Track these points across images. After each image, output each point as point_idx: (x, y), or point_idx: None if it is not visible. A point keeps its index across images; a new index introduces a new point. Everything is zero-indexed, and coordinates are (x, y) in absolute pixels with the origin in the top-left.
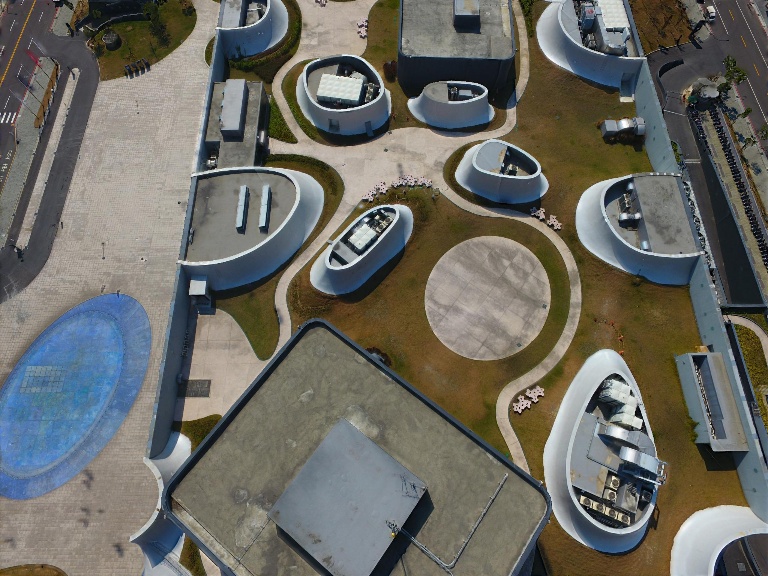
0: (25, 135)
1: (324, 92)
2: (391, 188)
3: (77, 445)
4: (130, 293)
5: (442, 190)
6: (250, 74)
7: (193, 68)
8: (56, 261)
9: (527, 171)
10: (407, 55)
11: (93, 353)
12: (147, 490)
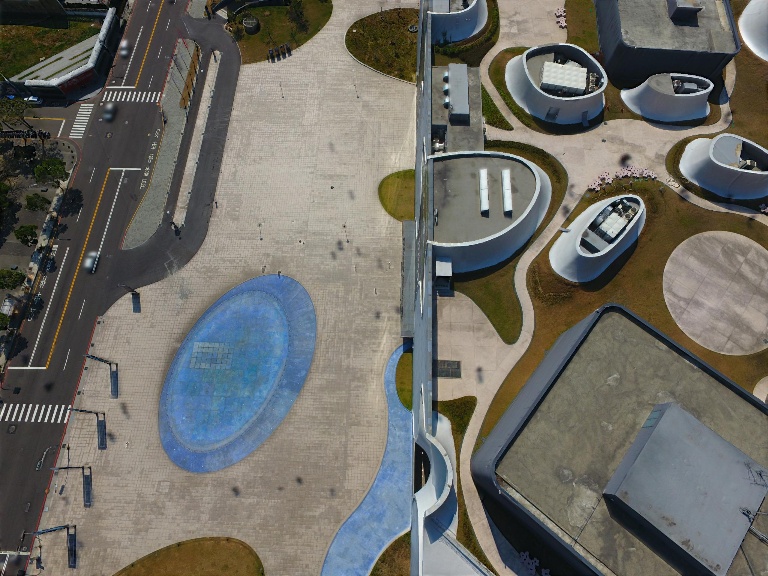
0: (172, 115)
1: (550, 80)
2: (615, 179)
3: (250, 422)
4: (291, 275)
5: (668, 183)
6: (455, 60)
7: (334, 55)
8: (214, 240)
9: (759, 167)
10: (631, 46)
11: (259, 332)
12: (325, 470)
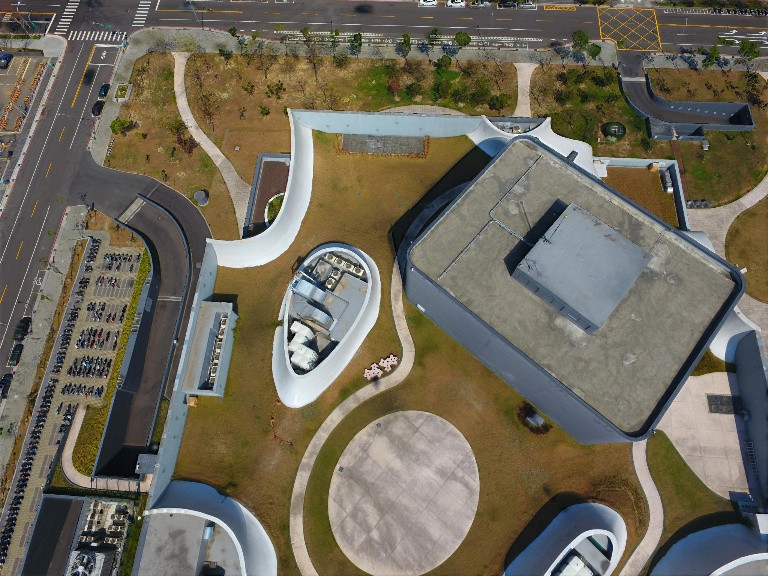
0: None
1: None
2: None
3: None
4: None
5: None
6: None
7: None
8: None
9: None
10: None
11: None
12: None
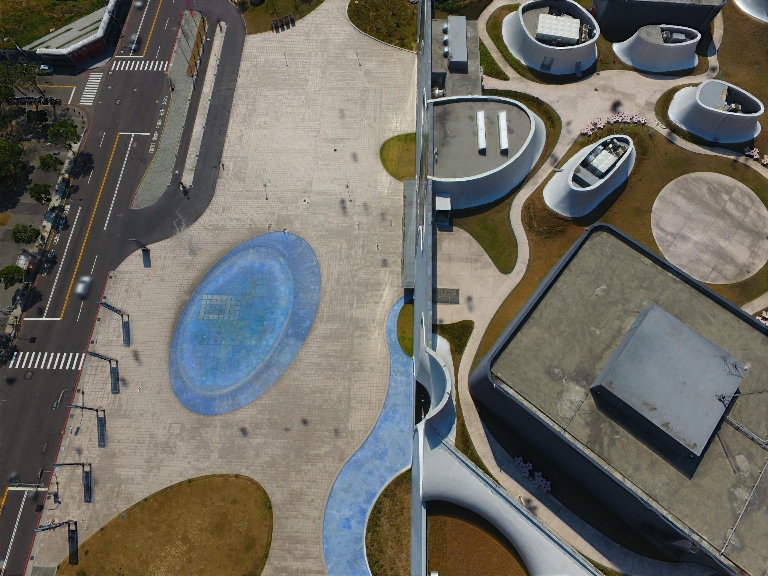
0: (179, 82)
1: (544, 30)
2: (607, 124)
3: (258, 369)
4: (296, 232)
5: (657, 128)
6: None
7: (337, 25)
8: (221, 200)
9: (743, 111)
10: None
11: (265, 285)
12: (329, 412)
